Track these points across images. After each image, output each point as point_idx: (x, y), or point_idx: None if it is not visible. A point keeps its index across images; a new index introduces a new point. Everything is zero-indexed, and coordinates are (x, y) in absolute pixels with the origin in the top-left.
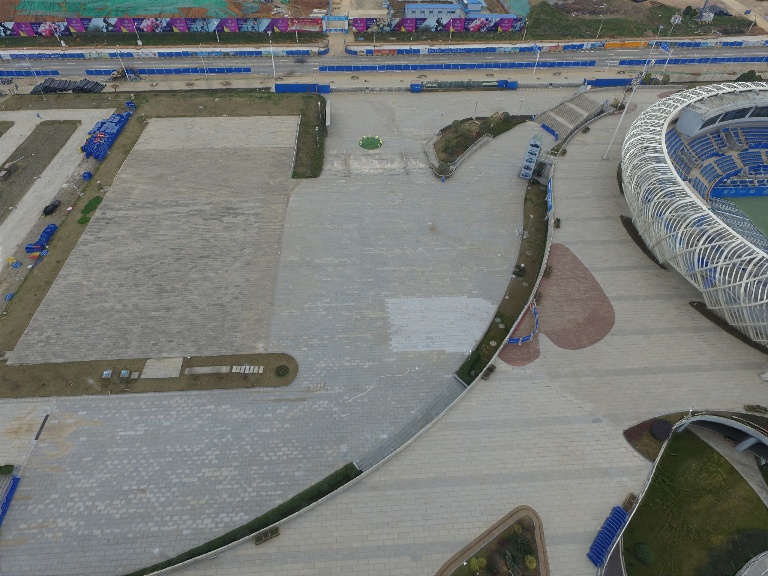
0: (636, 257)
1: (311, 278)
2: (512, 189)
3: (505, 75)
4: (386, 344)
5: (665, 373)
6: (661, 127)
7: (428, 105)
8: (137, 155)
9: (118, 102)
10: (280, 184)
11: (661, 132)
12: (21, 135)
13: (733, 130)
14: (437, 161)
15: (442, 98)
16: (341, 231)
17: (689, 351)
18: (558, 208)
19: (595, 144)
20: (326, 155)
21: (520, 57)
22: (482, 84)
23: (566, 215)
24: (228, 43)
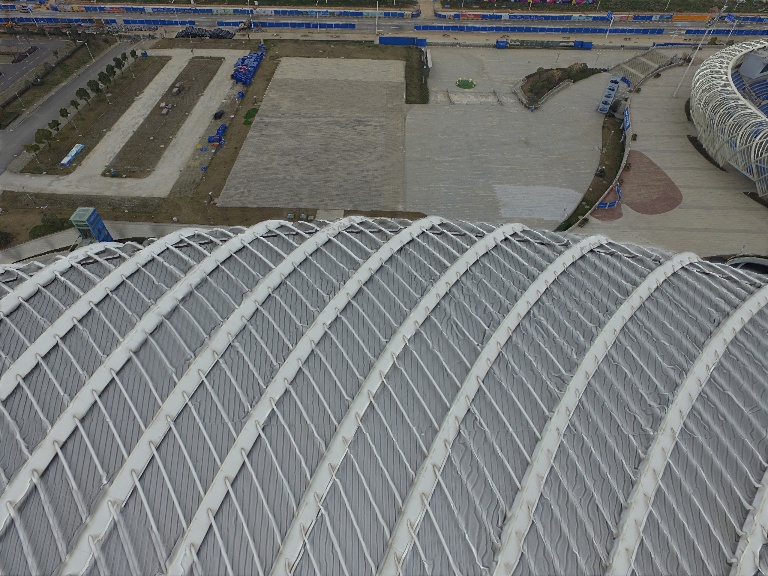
0: (700, 162)
1: (432, 169)
2: (591, 119)
3: (580, 38)
4: (497, 212)
5: (722, 232)
6: (727, 64)
7: (512, 58)
8: (277, 82)
9: (251, 45)
10: (397, 107)
11: (727, 67)
12: (188, 61)
13: None
14: (525, 98)
15: (524, 54)
16: (451, 140)
17: (742, 221)
18: (634, 128)
19: (665, 86)
20: (429, 91)
21: (593, 25)
22: (559, 44)
23: (641, 133)
24: (331, 6)
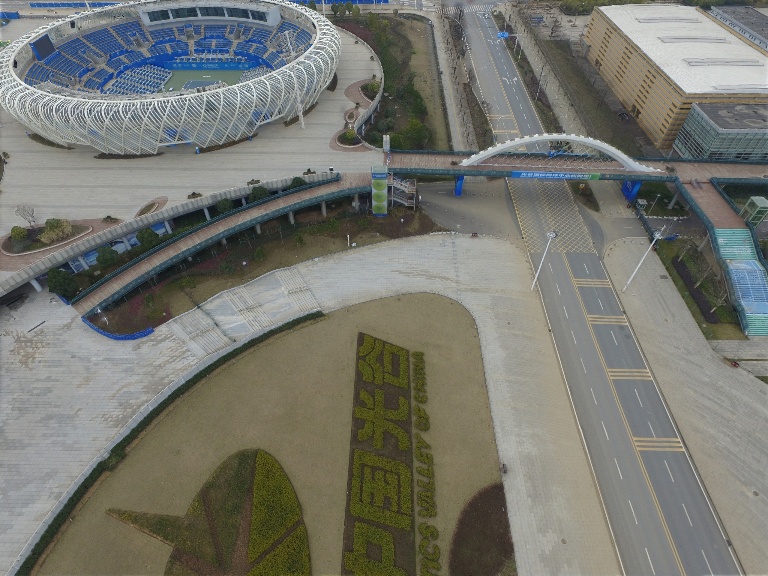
0: None
1: None
2: None
3: None
4: None
5: None
6: None
7: None
8: None
9: None
10: None
11: None
12: None
13: (198, 26)
14: None
15: None
16: None
17: None
18: None
19: None
20: None
21: None
22: None
23: None
24: None
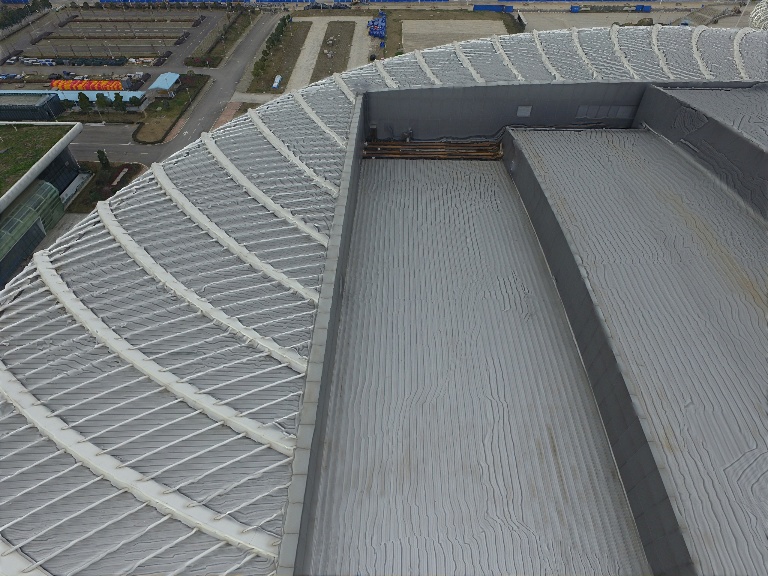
0: None
1: None
2: None
3: None
4: None
5: None
6: None
7: (587, 19)
8: (408, 35)
9: (371, 13)
10: None
11: None
12: None
13: None
14: None
15: (596, 16)
16: None
17: None
18: None
19: None
20: None
21: None
22: (623, 9)
23: None
24: None
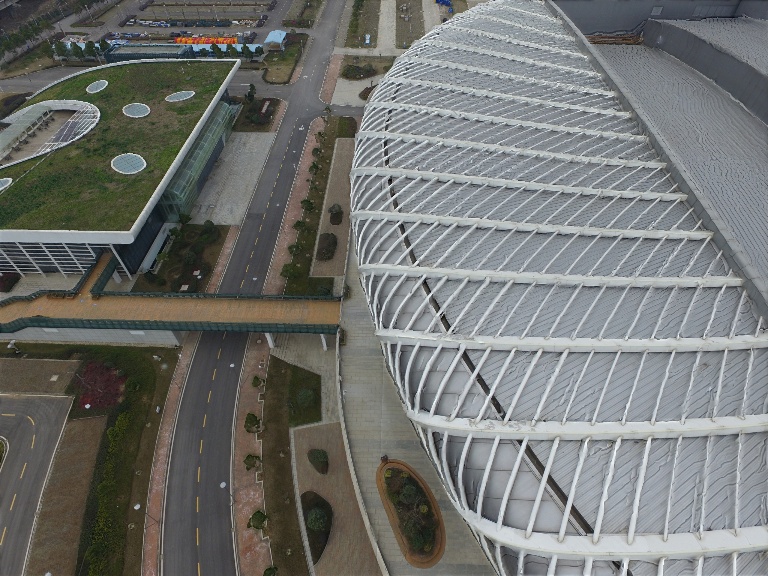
0: None
1: None
2: None
3: None
4: None
5: None
6: None
7: None
8: (472, 3)
9: None
10: None
11: None
12: None
13: None
14: None
15: None
16: None
17: None
18: None
19: None
20: None
21: None
22: None
23: None
24: None
